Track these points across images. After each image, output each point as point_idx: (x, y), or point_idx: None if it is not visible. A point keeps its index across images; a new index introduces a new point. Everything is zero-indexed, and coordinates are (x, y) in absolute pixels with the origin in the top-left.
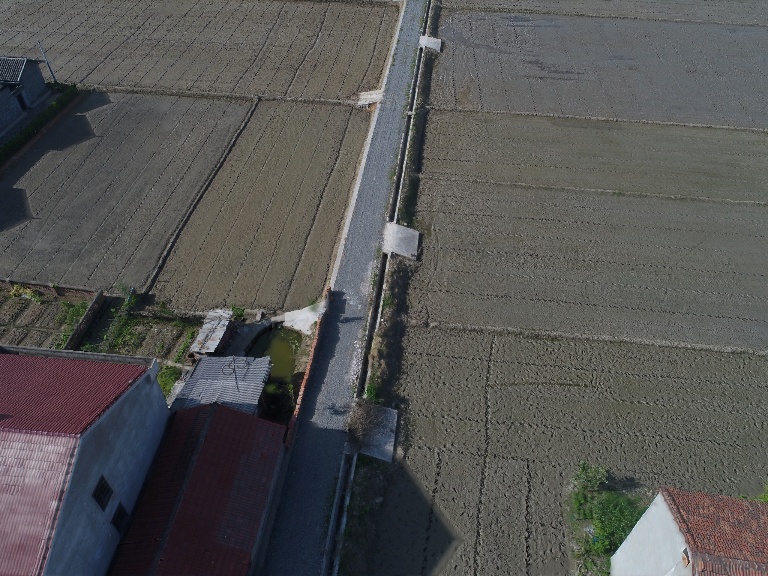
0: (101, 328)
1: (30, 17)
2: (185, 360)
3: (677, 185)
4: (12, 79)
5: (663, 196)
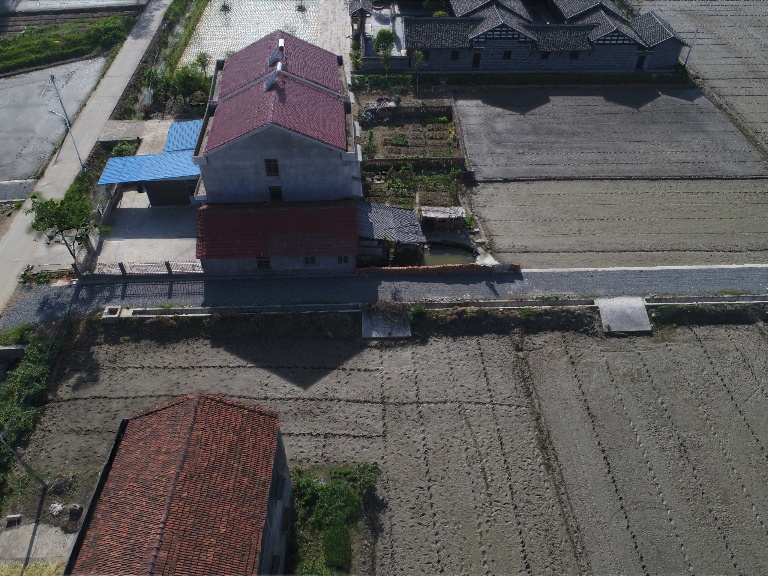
0: (436, 172)
1: None
2: None
3: None
4: (649, 43)
5: None
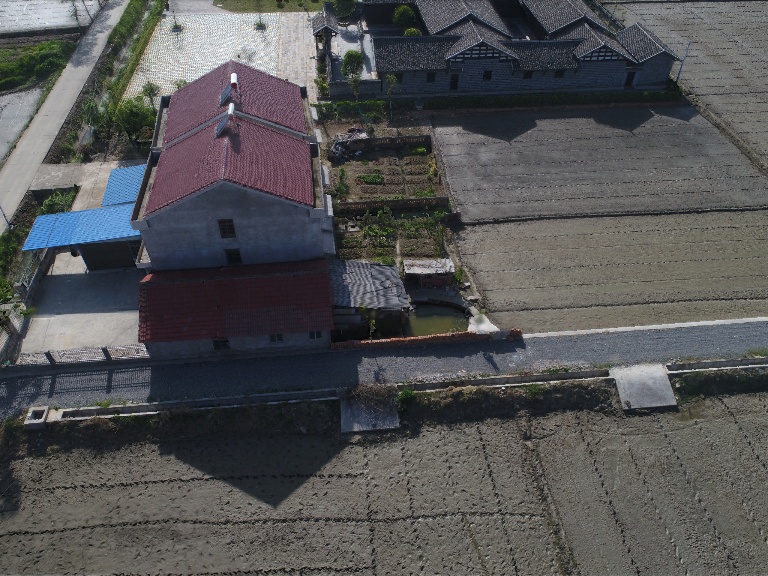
0: (418, 214)
1: (764, 35)
2: None
3: None
4: (639, 58)
5: None
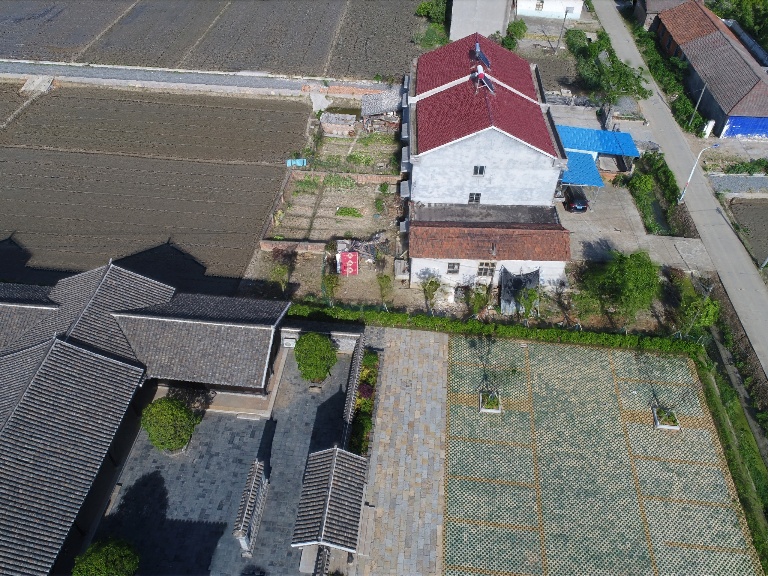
0: None
1: None
2: (351, 138)
3: (218, 1)
4: None
5: (228, 6)
